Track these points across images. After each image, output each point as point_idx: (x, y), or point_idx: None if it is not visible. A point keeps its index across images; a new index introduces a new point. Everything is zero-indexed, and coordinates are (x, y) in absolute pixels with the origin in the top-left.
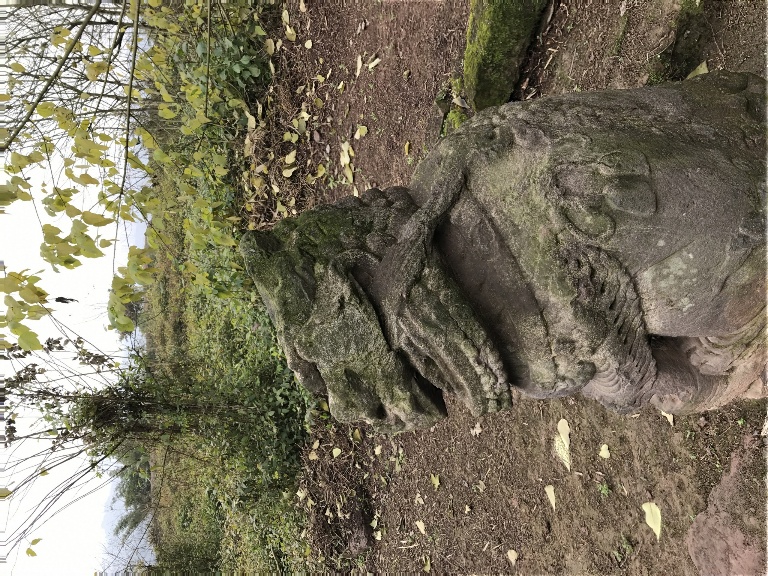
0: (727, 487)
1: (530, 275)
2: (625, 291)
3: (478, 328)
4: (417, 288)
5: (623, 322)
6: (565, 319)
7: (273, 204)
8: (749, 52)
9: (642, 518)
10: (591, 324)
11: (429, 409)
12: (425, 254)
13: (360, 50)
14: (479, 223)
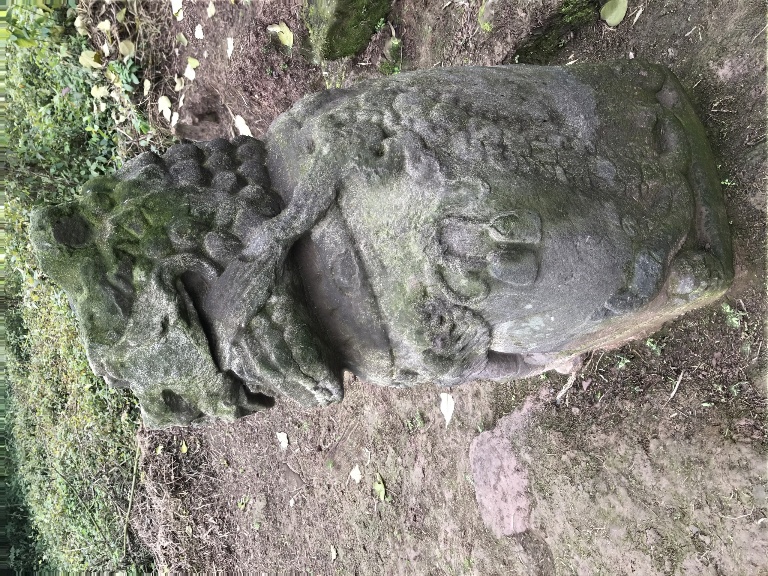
0: (515, 422)
1: (388, 316)
2: (480, 337)
3: (321, 368)
4: (259, 319)
5: (469, 353)
6: (414, 359)
7: None
8: (674, 6)
9: (438, 403)
10: (438, 367)
11: (255, 409)
12: (274, 281)
13: None
14: (343, 253)
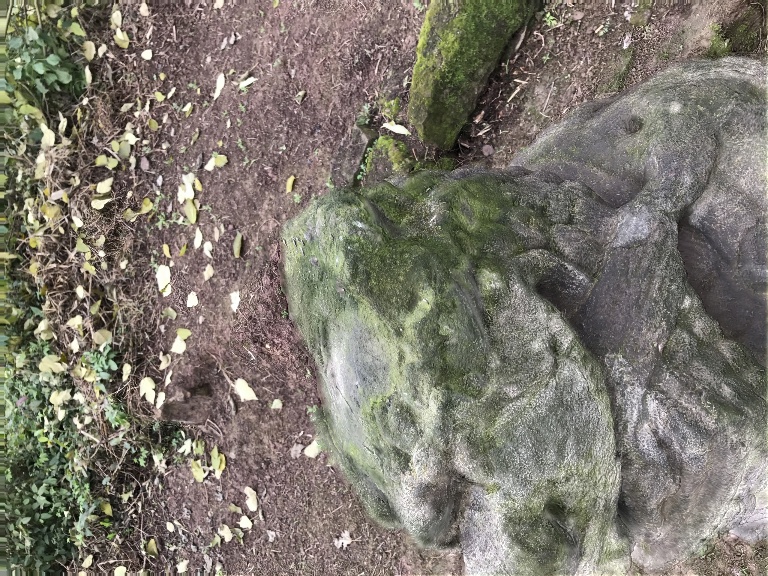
0: None
1: None
2: None
3: None
4: (681, 334)
5: None
6: None
7: (70, 241)
8: None
9: None
10: None
11: None
12: None
13: (223, 67)
14: (755, 225)
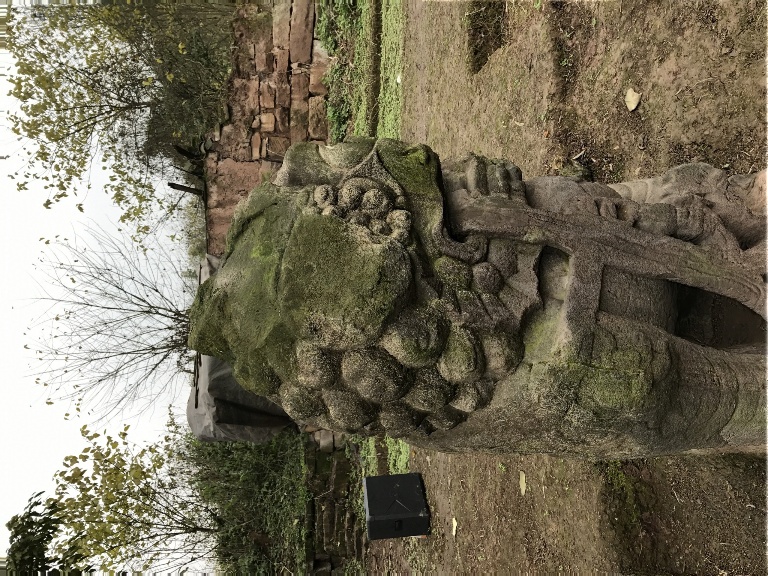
0: None
1: None
2: None
3: None
4: None
5: None
6: None
7: None
8: (763, 545)
9: None
10: None
11: None
12: None
13: None
14: None
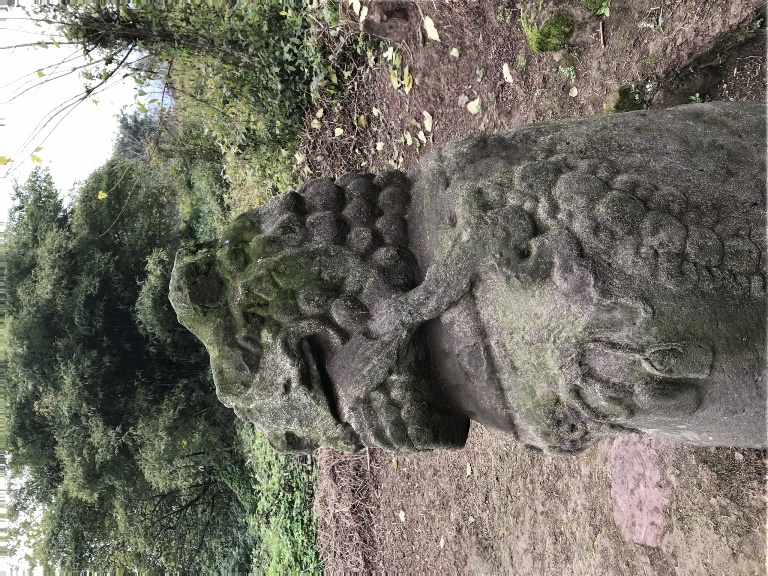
0: None
1: (515, 408)
2: None
3: (437, 445)
4: (378, 394)
5: None
6: (539, 444)
7: None
8: None
9: None
10: (566, 455)
11: None
12: (396, 363)
13: None
14: (472, 345)
